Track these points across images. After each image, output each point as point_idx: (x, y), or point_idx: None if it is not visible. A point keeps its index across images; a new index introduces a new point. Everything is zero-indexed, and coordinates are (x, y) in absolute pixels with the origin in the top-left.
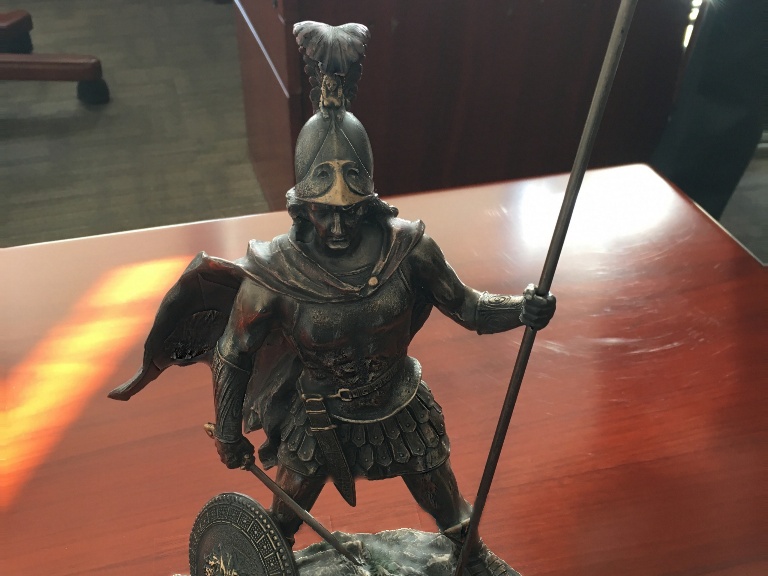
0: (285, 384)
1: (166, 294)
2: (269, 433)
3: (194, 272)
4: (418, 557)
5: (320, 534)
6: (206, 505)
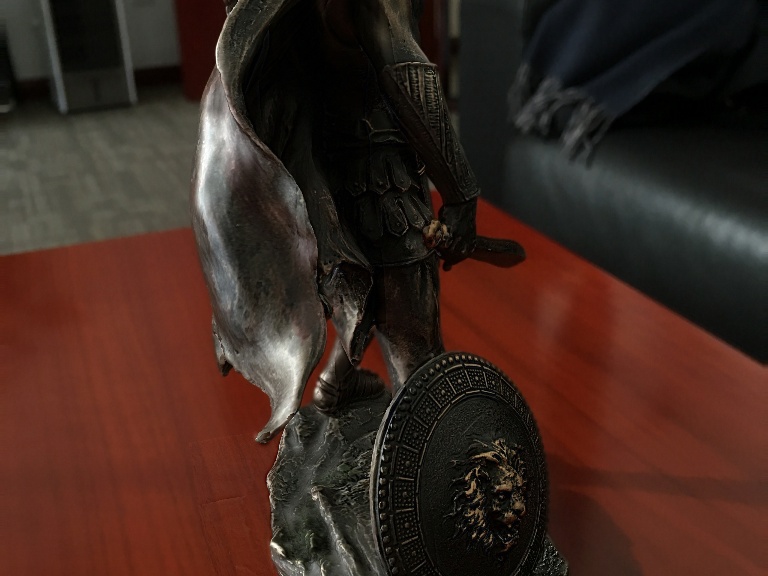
0: (332, 192)
1: (241, 119)
2: (371, 265)
3: (263, 33)
4: (326, 452)
5: (512, 252)
6: (384, 479)
